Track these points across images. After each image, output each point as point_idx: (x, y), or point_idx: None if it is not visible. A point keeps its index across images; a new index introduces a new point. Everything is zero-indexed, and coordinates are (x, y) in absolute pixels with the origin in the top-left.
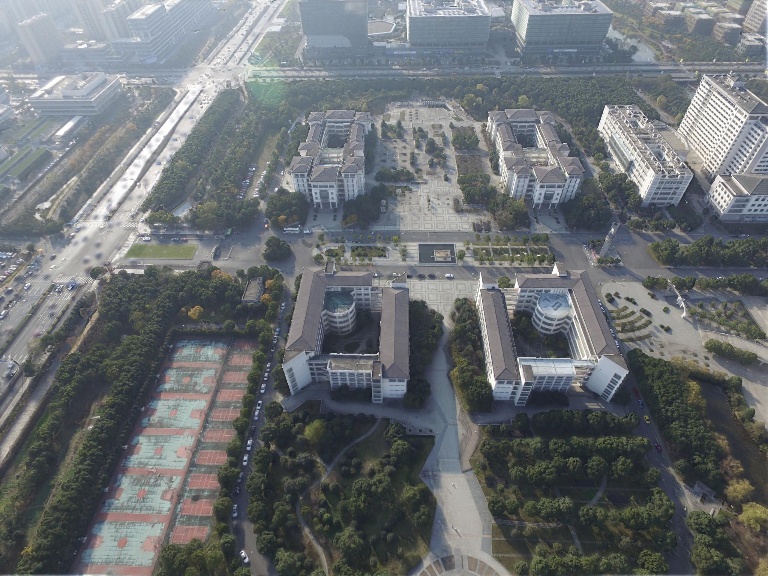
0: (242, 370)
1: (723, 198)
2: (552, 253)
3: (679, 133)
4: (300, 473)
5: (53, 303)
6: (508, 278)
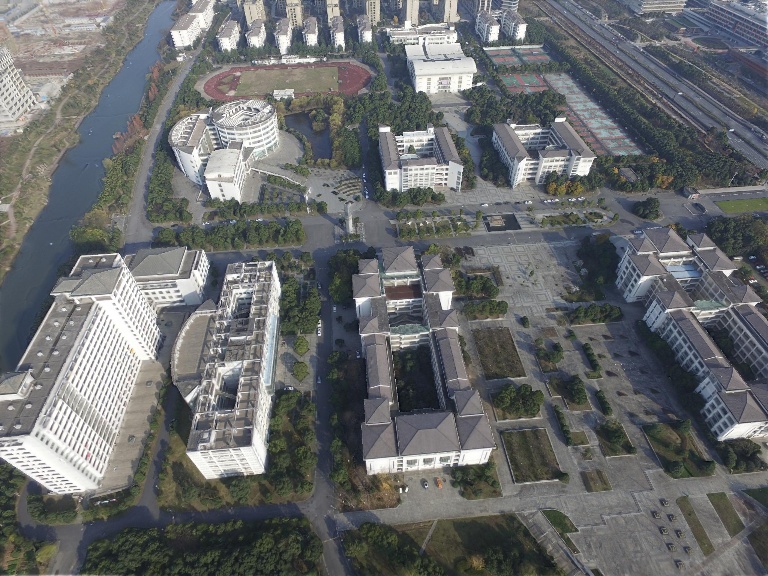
0: (593, 148)
1: (204, 264)
2: (400, 213)
3: (173, 357)
4: (528, 116)
5: (767, 165)
6: (438, 195)
